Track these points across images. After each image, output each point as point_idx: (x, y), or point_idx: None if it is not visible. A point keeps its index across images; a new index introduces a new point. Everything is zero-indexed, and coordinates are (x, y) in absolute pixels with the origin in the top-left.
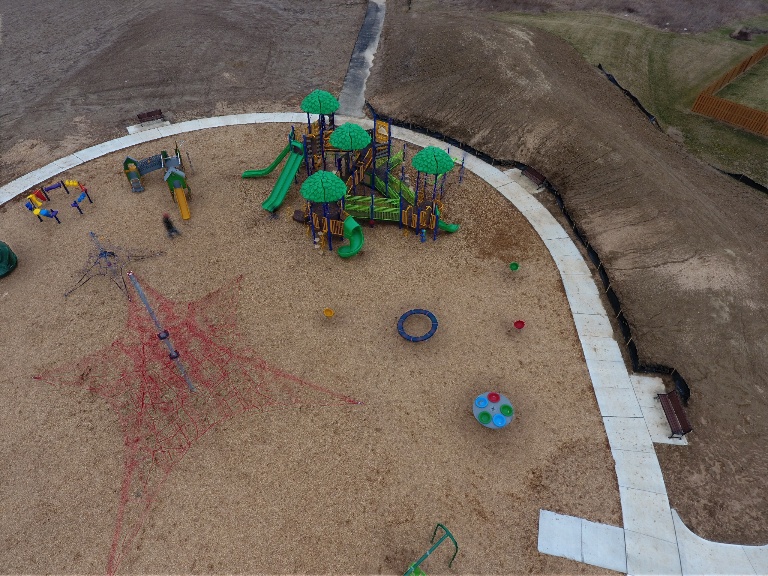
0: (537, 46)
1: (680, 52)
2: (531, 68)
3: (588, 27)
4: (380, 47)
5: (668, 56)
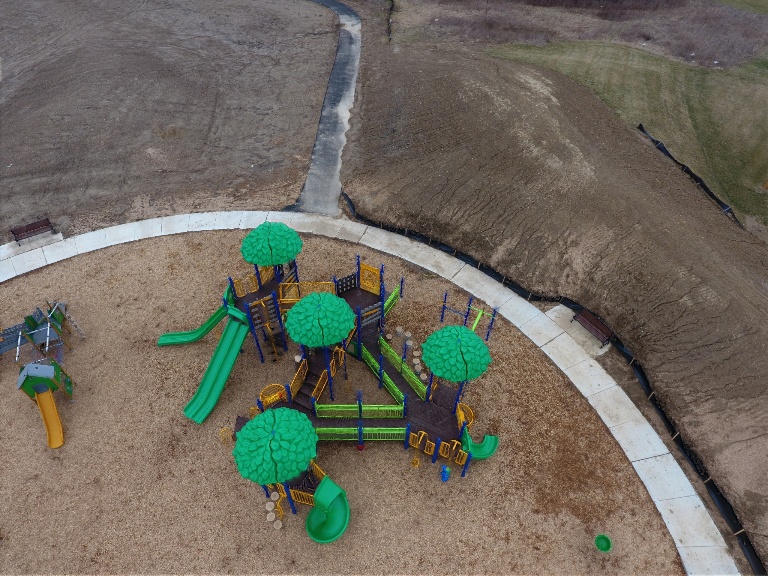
0: (562, 104)
1: (720, 95)
2: (563, 142)
3: (609, 66)
4: (357, 98)
5: (708, 102)
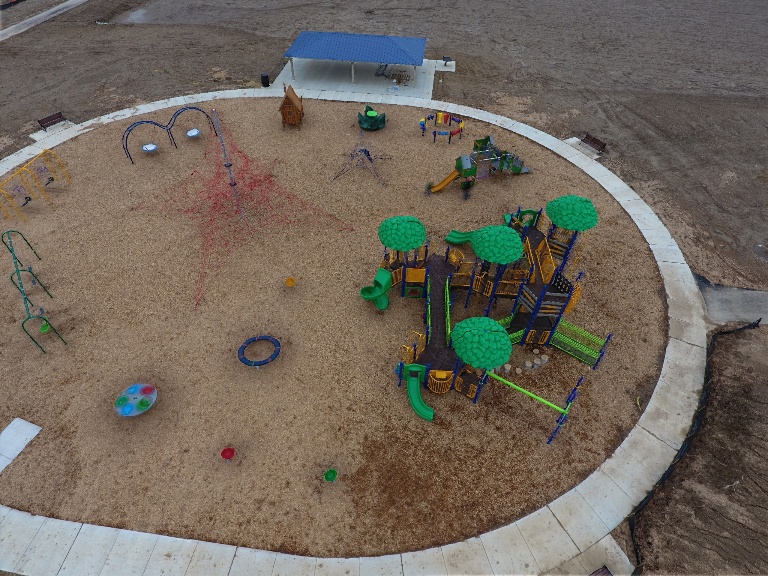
0: None
1: None
2: None
3: None
4: None
5: None
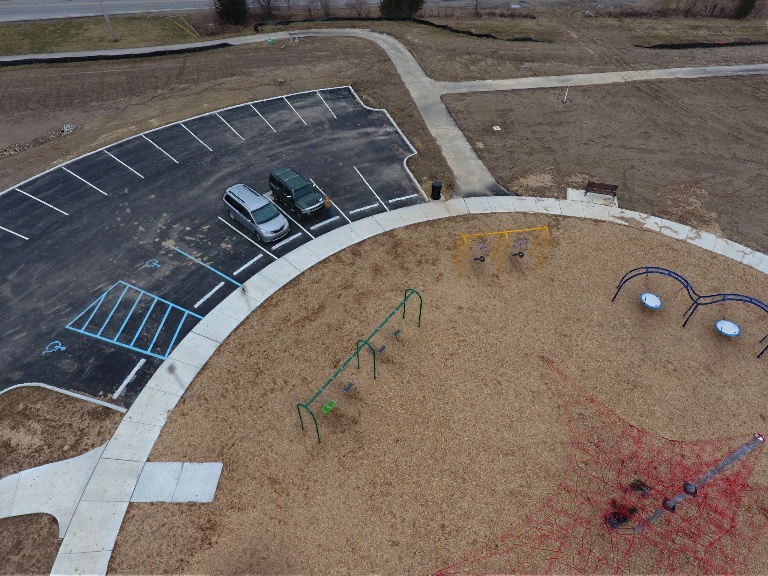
0: None
1: None
2: None
3: None
4: None
5: None
